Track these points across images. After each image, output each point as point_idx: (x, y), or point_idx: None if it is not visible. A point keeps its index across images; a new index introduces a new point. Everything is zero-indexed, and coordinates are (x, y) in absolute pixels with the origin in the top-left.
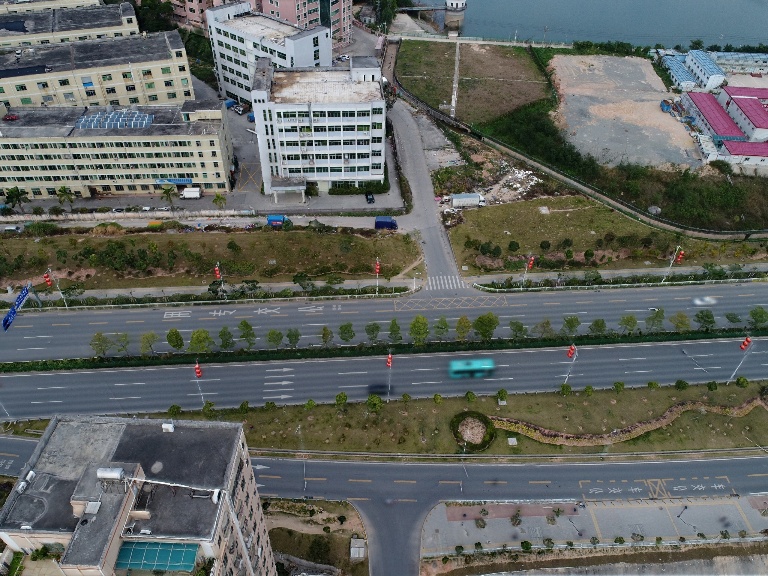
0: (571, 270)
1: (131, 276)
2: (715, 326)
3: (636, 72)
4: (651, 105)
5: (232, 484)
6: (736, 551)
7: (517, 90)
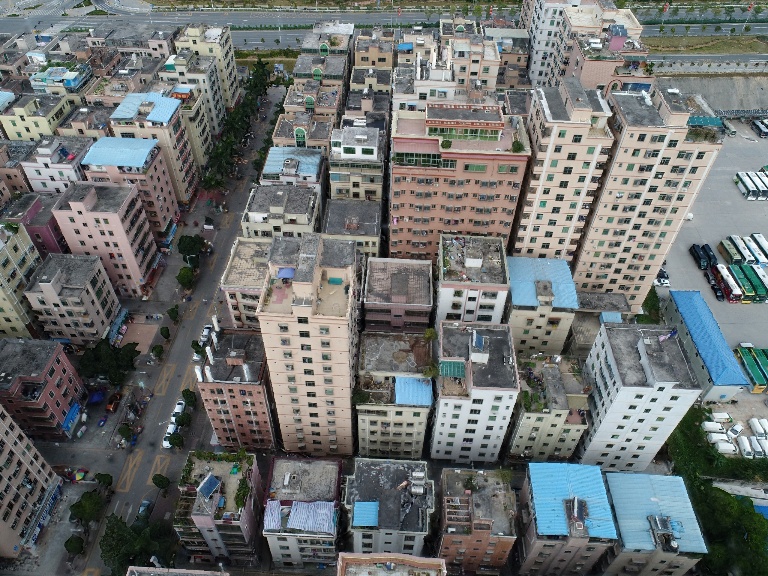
0: (654, 3)
1: (416, 1)
2: (734, 18)
3: None
4: None
5: None
6: (743, 75)
7: None
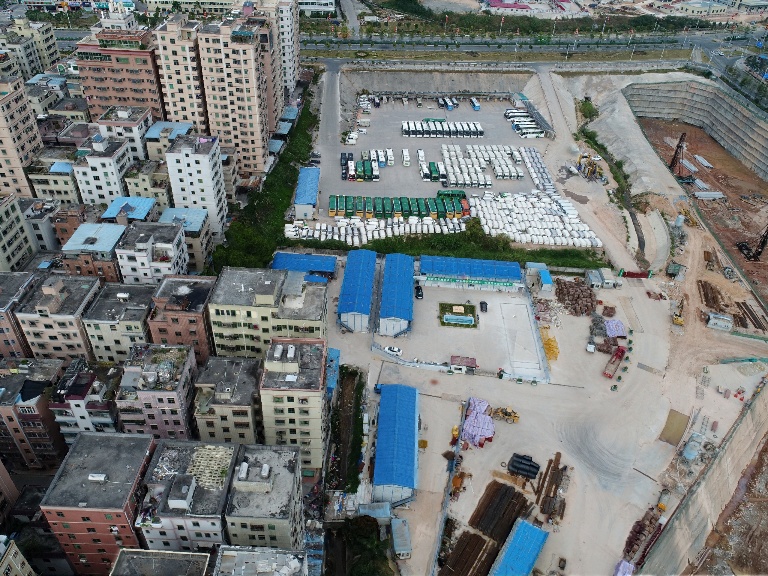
0: None
1: None
2: None
3: None
4: None
5: None
6: (440, 71)
7: None
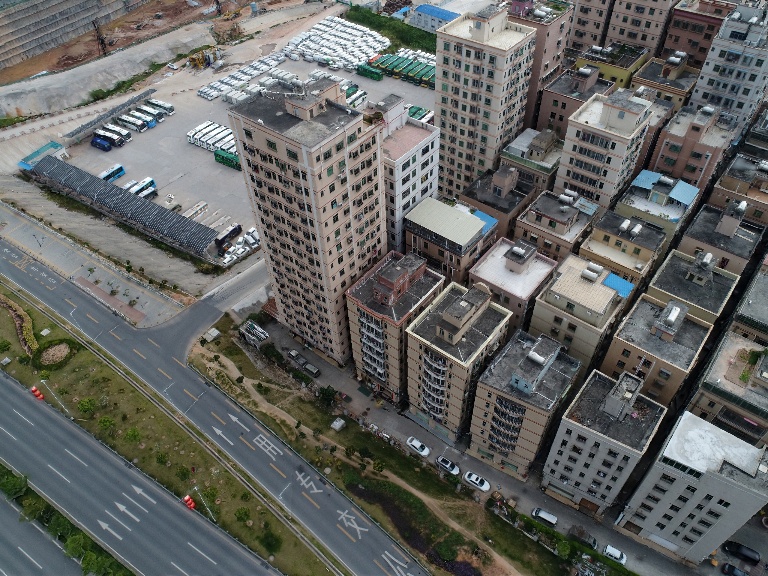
0: None
1: None
2: None
3: None
4: None
5: None
6: (45, 224)
7: None
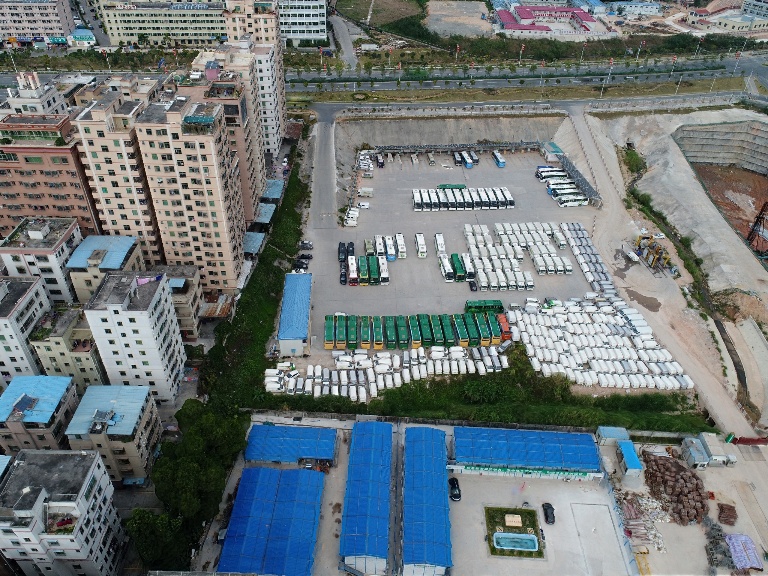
0: None
1: None
2: None
3: (475, 6)
4: (477, 17)
5: (277, 2)
6: (454, 117)
7: (404, 13)
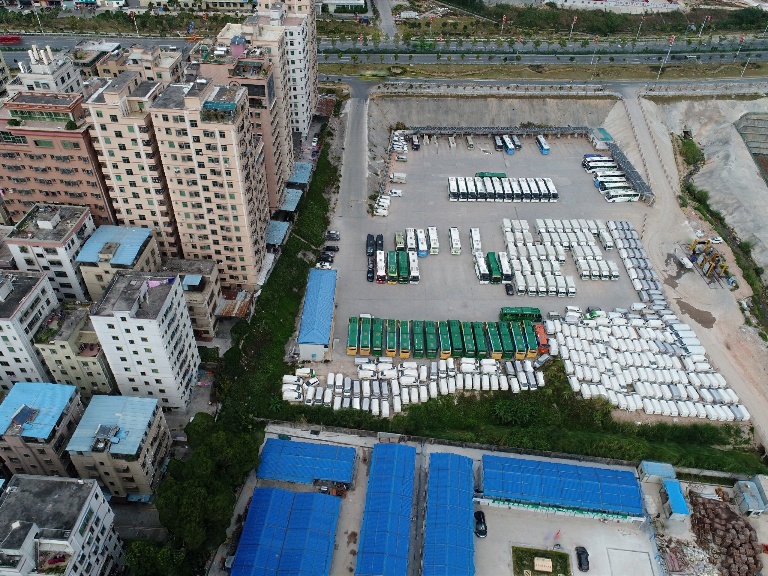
0: None
1: None
2: (518, 50)
3: None
4: None
5: None
6: (497, 97)
7: None
